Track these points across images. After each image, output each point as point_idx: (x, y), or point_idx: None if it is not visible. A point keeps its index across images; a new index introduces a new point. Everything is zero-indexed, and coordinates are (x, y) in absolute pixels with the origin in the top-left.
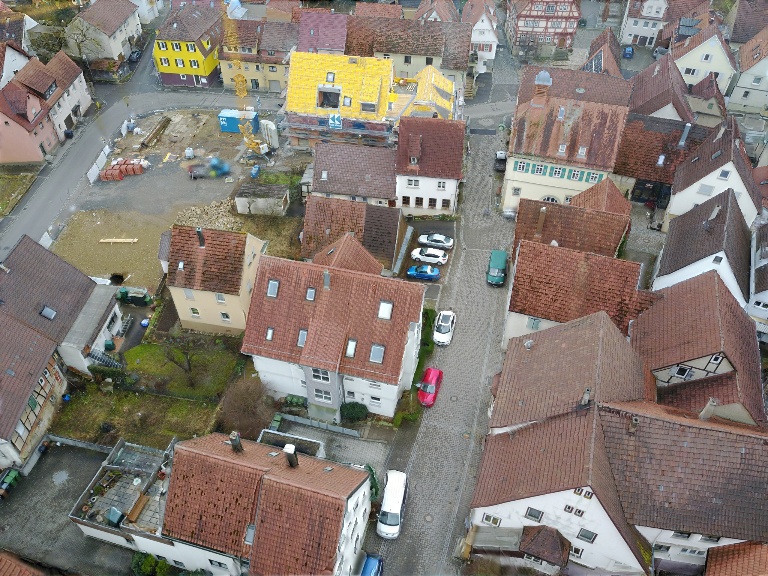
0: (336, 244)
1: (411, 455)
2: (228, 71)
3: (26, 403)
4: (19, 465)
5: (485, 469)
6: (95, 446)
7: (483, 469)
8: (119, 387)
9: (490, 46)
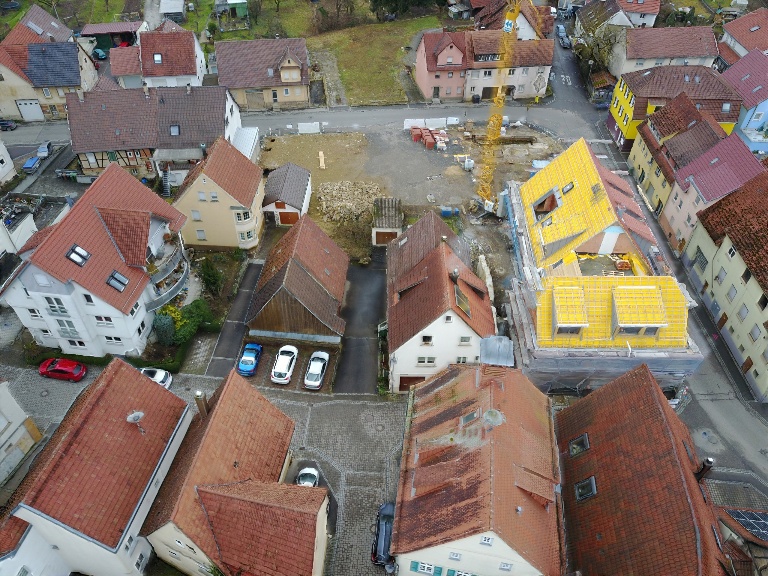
0: None
1: None
2: (637, 146)
3: (103, 150)
4: None
5: None
6: None
7: None
8: None
9: None
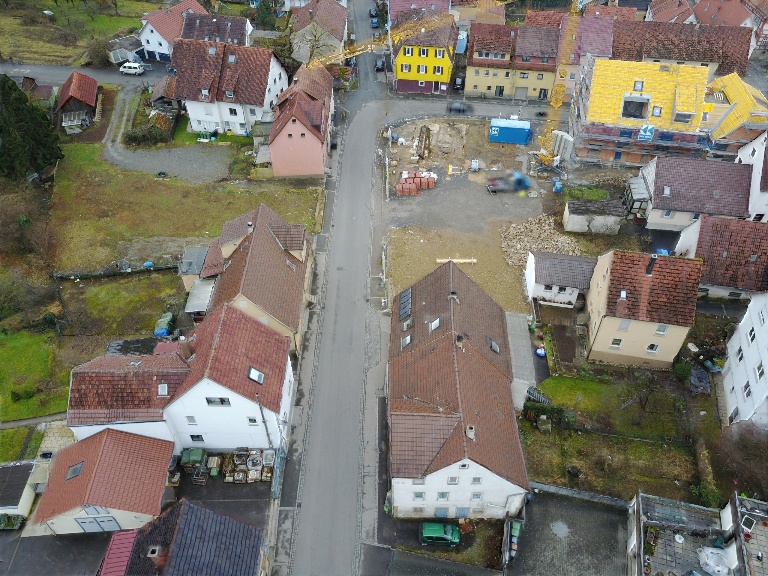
0: None
1: None
2: (473, 78)
3: (521, 448)
4: (510, 515)
5: None
6: (585, 494)
7: None
8: (554, 425)
9: None
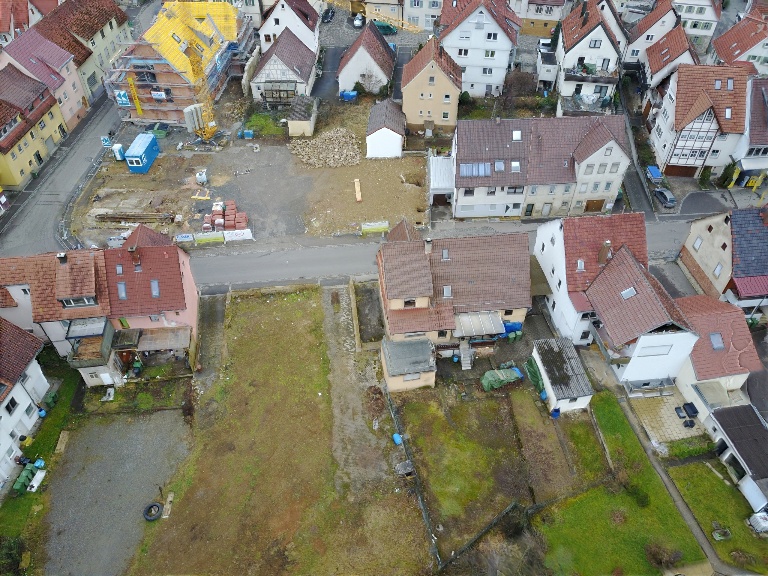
0: (448, 2)
1: (523, 48)
2: (14, 164)
3: None
4: None
5: (547, 1)
6: None
7: (547, 2)
8: None
9: None
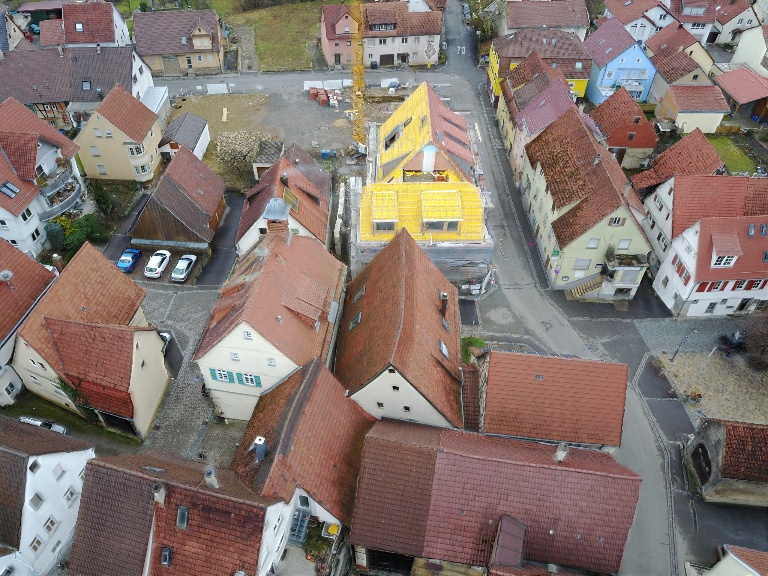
0: None
1: None
2: None
3: None
4: None
5: None
6: None
7: None
8: None
9: (688, 277)
